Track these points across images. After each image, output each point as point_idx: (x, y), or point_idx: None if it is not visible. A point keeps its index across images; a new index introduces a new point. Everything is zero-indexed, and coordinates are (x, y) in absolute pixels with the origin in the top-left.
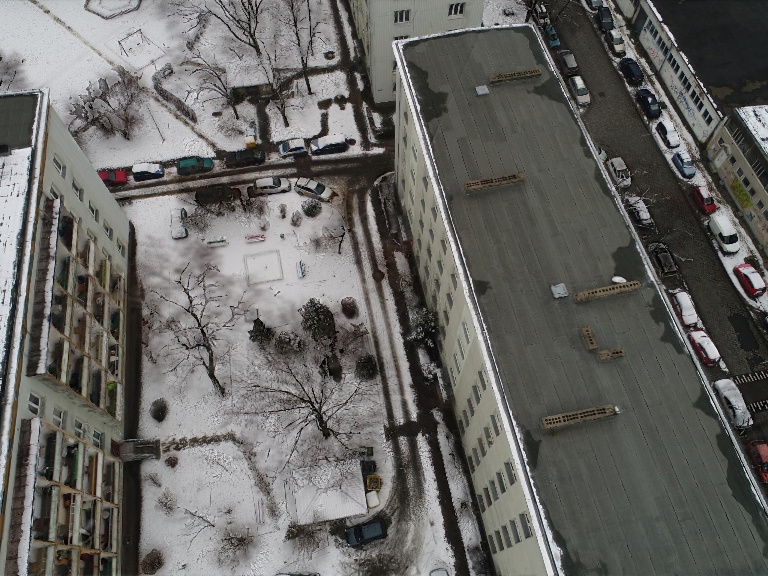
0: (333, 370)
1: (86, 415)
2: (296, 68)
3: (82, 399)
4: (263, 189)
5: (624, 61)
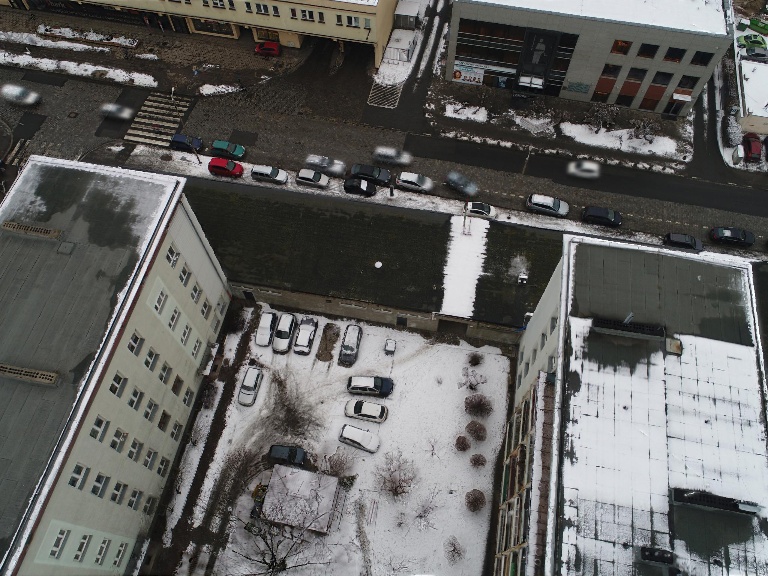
0: None
1: None
2: None
3: None
4: None
5: None
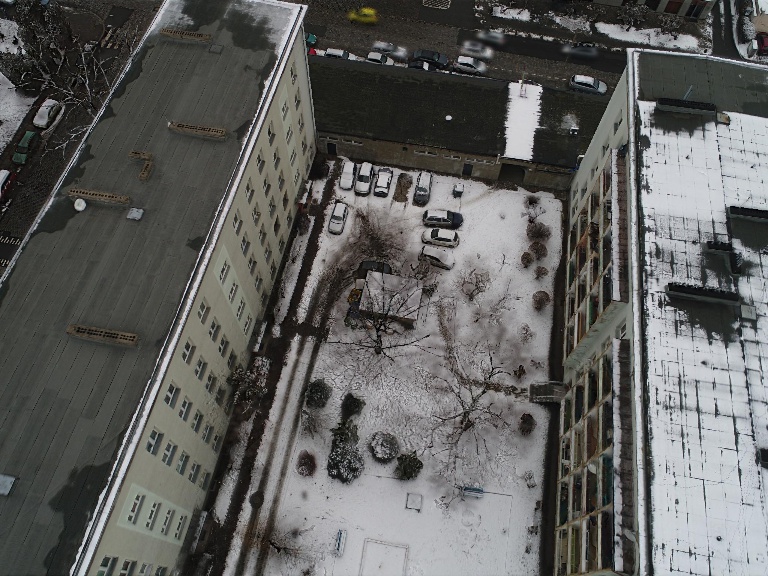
0: None
1: None
2: None
3: None
4: None
5: None
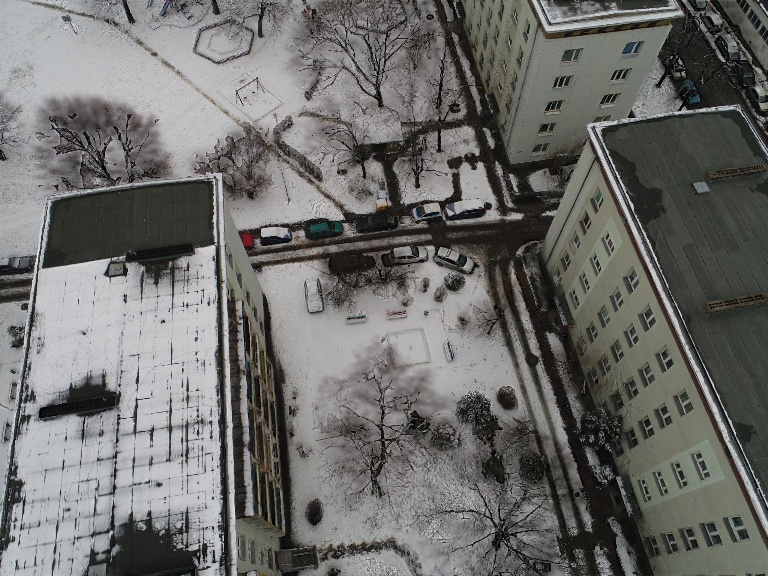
0: (498, 471)
1: (263, 536)
2: (421, 122)
3: (267, 525)
4: (401, 259)
5: None
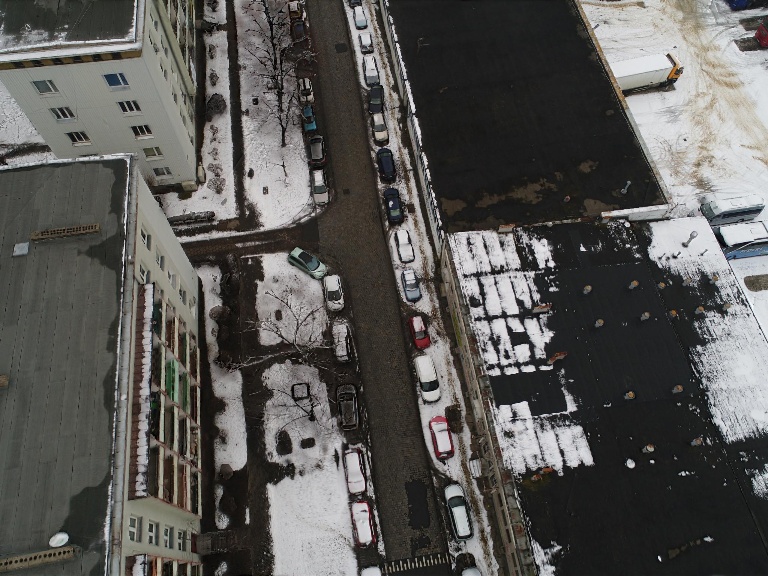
0: None
1: None
2: (13, 144)
3: None
4: None
5: (380, 153)
